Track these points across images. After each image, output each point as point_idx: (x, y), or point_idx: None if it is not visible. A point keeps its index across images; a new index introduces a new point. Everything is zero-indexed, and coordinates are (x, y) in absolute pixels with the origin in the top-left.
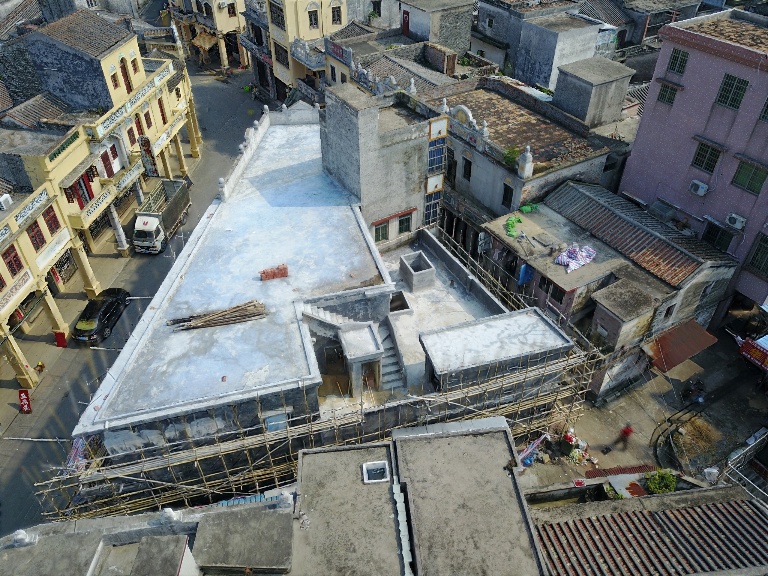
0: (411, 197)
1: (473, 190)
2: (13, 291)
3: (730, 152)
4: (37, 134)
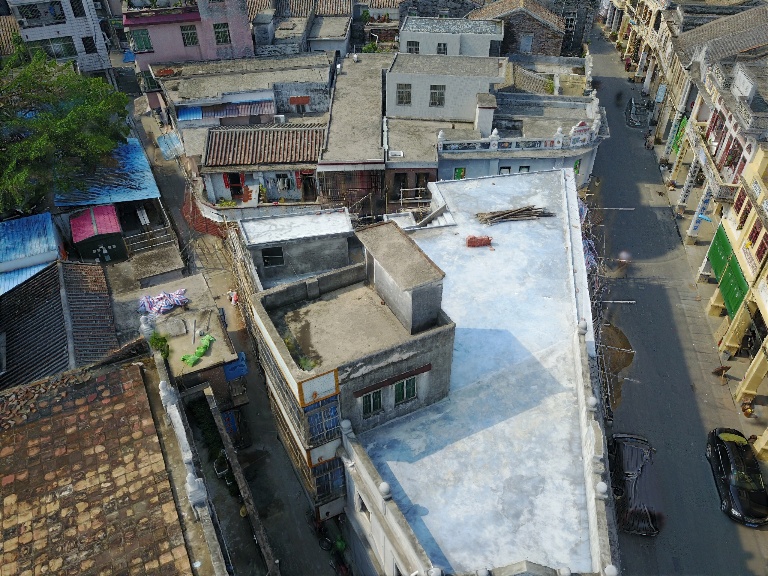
0: None
1: None
2: None
3: None
4: None
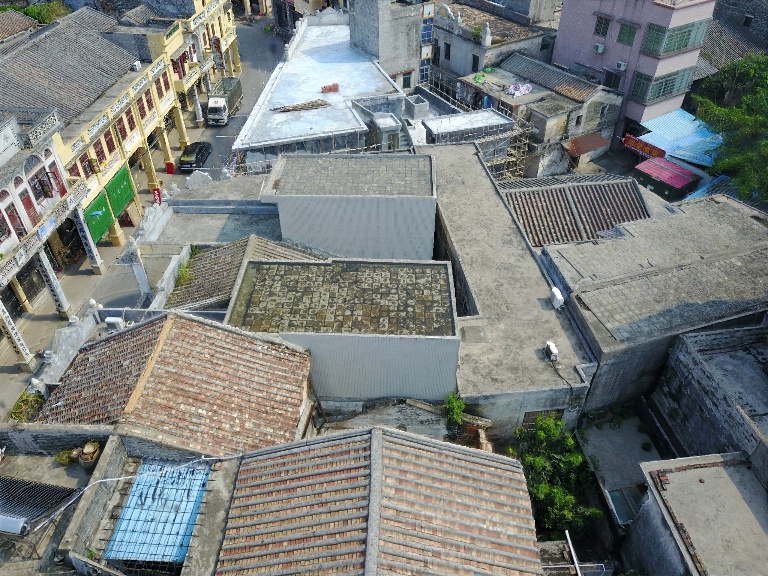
0: (411, 60)
1: (452, 66)
2: (149, 121)
3: (615, 19)
4: (147, 28)
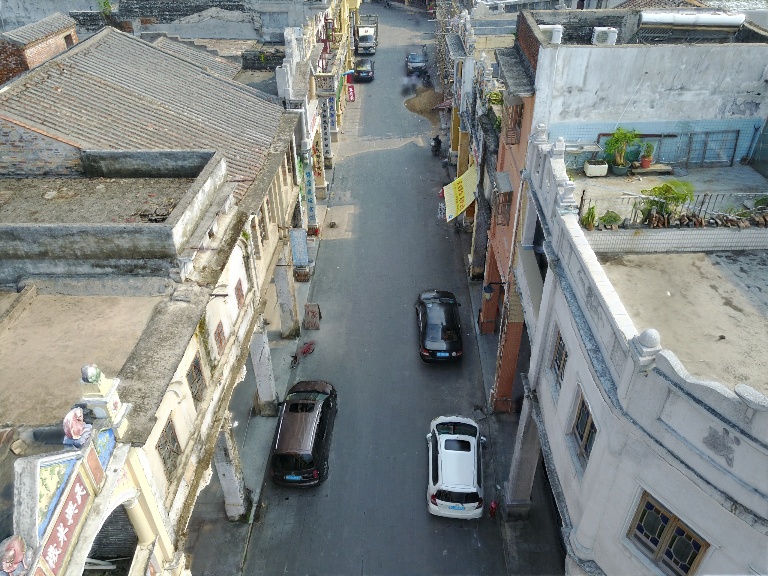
0: None
1: None
2: None
3: None
4: None
